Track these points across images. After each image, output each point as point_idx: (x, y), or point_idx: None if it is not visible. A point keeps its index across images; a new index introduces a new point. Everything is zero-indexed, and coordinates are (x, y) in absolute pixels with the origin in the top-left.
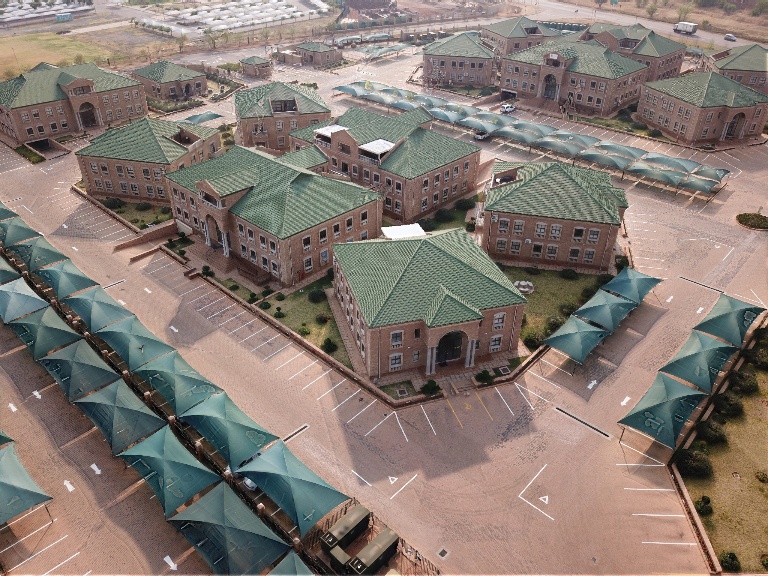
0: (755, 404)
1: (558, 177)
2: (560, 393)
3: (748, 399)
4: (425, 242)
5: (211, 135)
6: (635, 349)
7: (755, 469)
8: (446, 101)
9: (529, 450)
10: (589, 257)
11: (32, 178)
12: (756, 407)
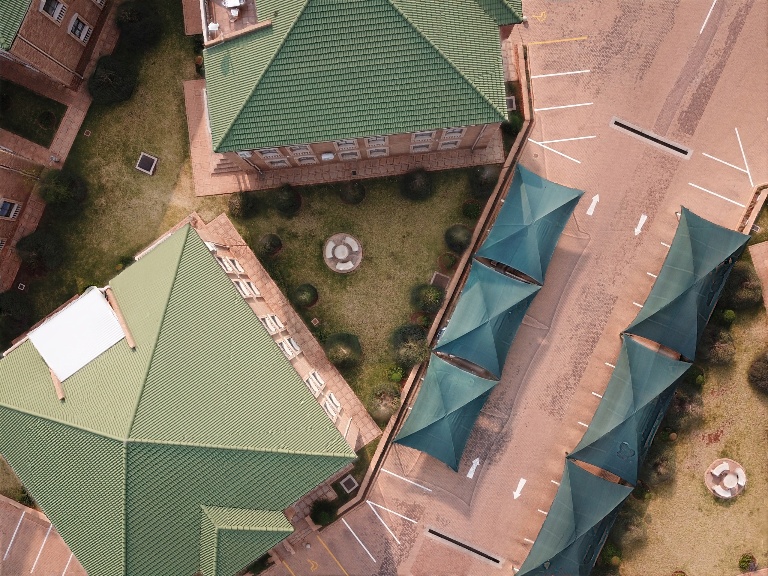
0: (692, 446)
1: (353, 4)
2: (431, 501)
3: (685, 439)
4: (131, 446)
5: None
6: (533, 367)
7: (673, 568)
8: None
9: None
10: (449, 142)
11: None
12: (693, 452)
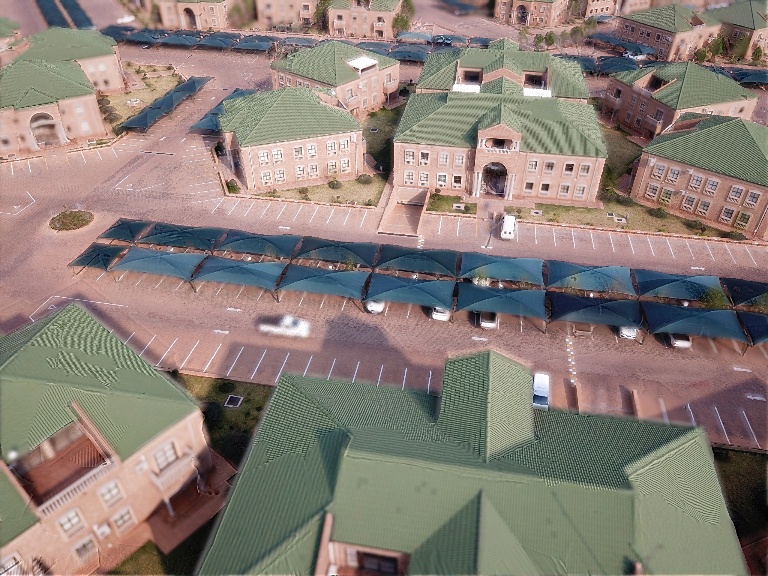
0: None
1: None
2: None
3: None
4: None
5: (662, 101)
6: None
7: (156, 91)
8: (655, 329)
9: (253, 81)
10: None
11: (755, 107)
12: None
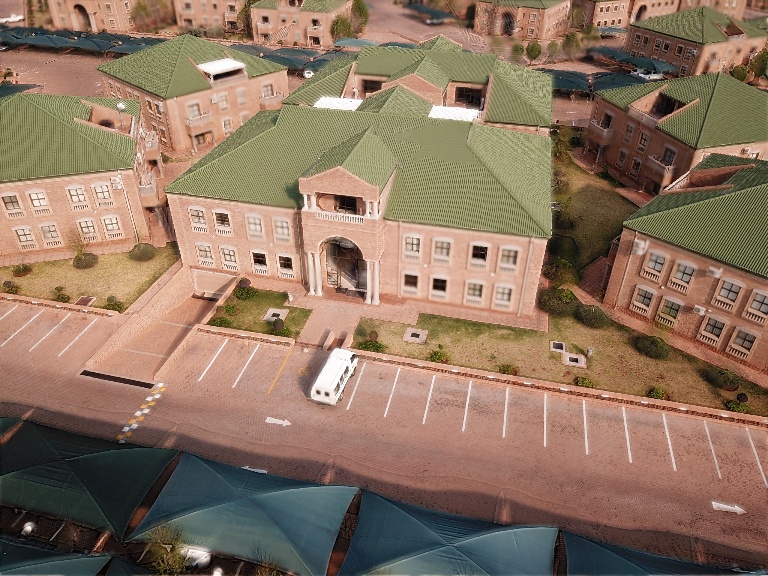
0: None
1: None
2: None
3: None
4: None
5: (674, 134)
6: None
7: None
8: None
9: None
10: None
11: None
12: None
